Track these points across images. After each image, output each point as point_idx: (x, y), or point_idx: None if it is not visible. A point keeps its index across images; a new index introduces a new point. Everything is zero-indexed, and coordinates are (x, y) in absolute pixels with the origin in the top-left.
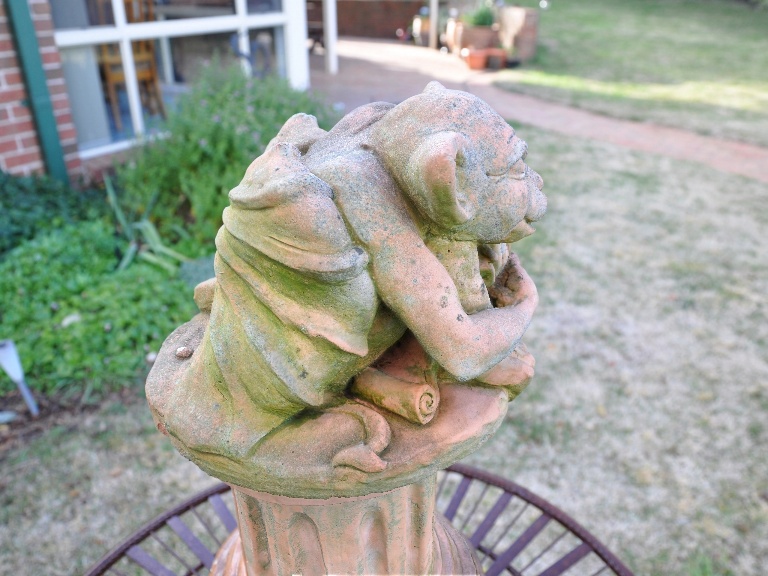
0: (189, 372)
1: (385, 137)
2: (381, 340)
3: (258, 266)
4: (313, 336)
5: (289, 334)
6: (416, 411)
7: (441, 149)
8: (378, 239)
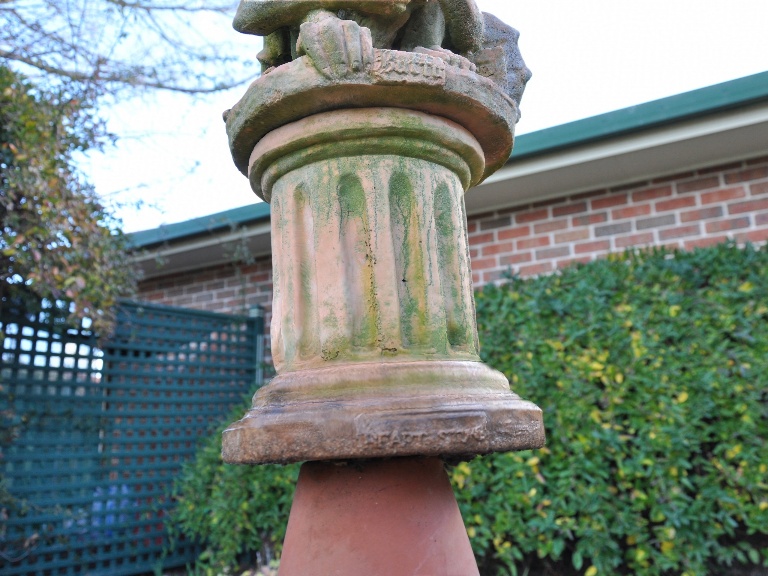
0: None
1: None
2: None
3: None
4: None
5: None
6: None
7: None
8: None
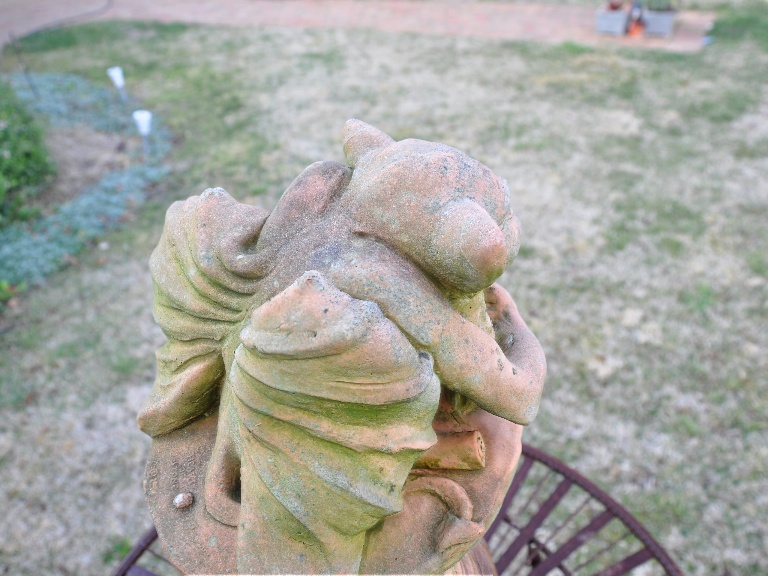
0: (248, 535)
1: (385, 220)
2: None
3: (315, 408)
4: (396, 452)
5: (367, 459)
6: (479, 461)
7: (496, 238)
8: (436, 336)
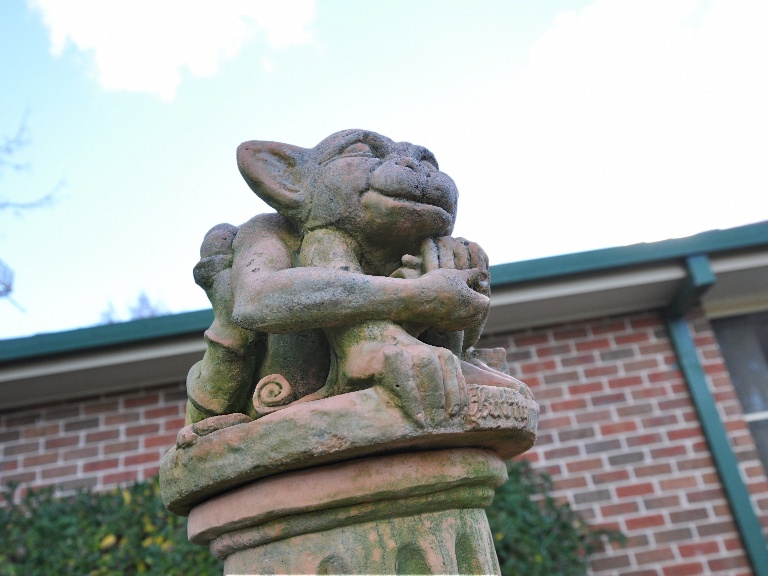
0: None
1: None
2: (279, 353)
3: None
4: None
5: None
6: None
7: None
8: None
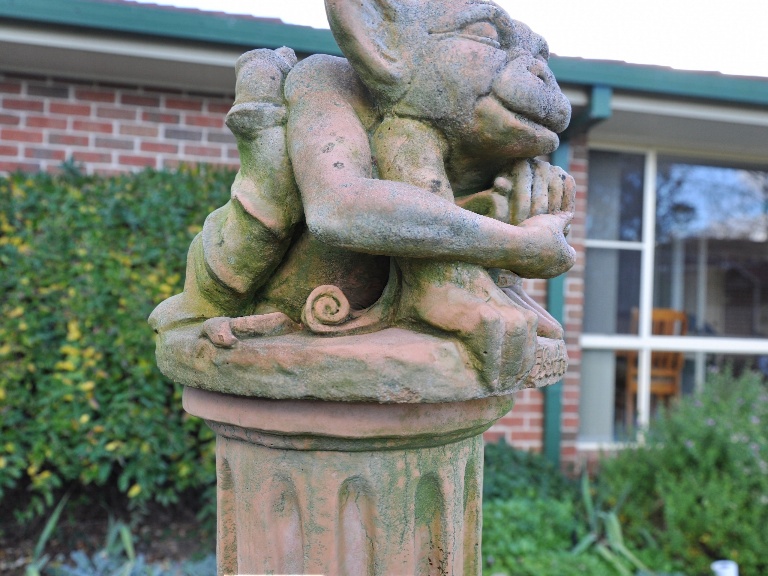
0: None
1: None
2: (324, 244)
3: None
4: (233, 199)
5: None
6: (306, 307)
7: None
8: (298, 95)
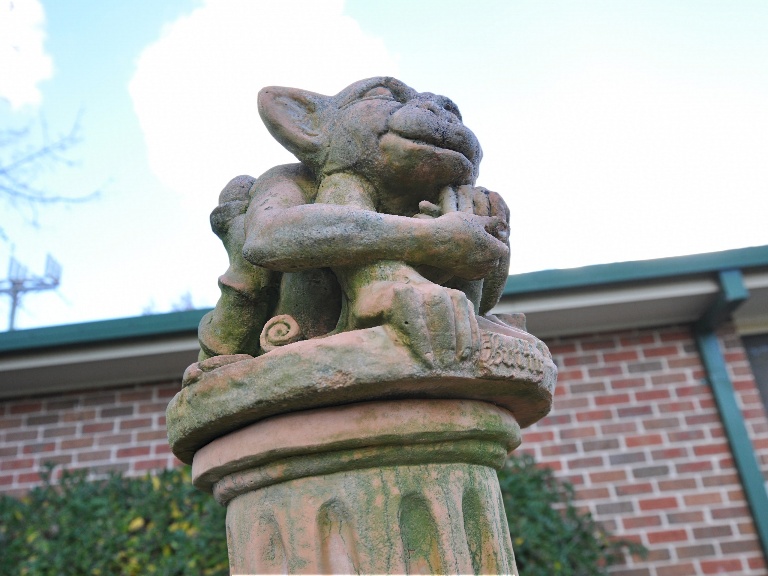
0: None
1: None
2: (291, 299)
3: None
4: None
5: None
6: None
7: None
8: None
